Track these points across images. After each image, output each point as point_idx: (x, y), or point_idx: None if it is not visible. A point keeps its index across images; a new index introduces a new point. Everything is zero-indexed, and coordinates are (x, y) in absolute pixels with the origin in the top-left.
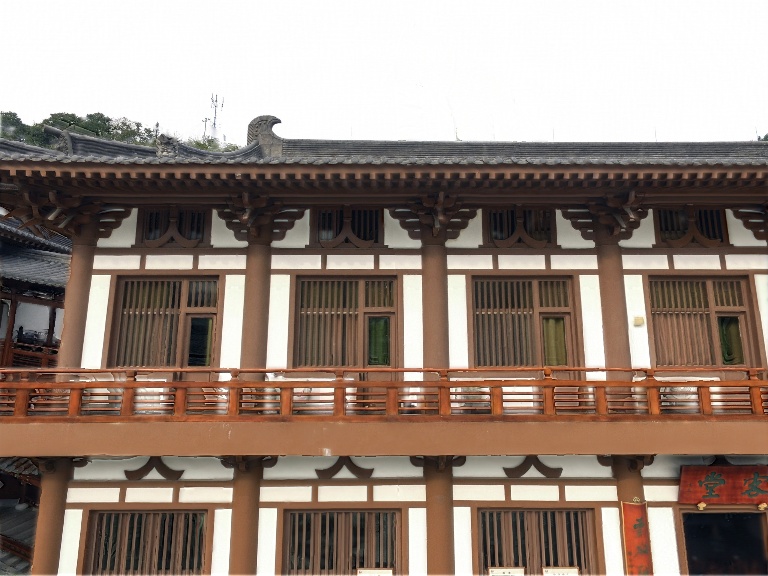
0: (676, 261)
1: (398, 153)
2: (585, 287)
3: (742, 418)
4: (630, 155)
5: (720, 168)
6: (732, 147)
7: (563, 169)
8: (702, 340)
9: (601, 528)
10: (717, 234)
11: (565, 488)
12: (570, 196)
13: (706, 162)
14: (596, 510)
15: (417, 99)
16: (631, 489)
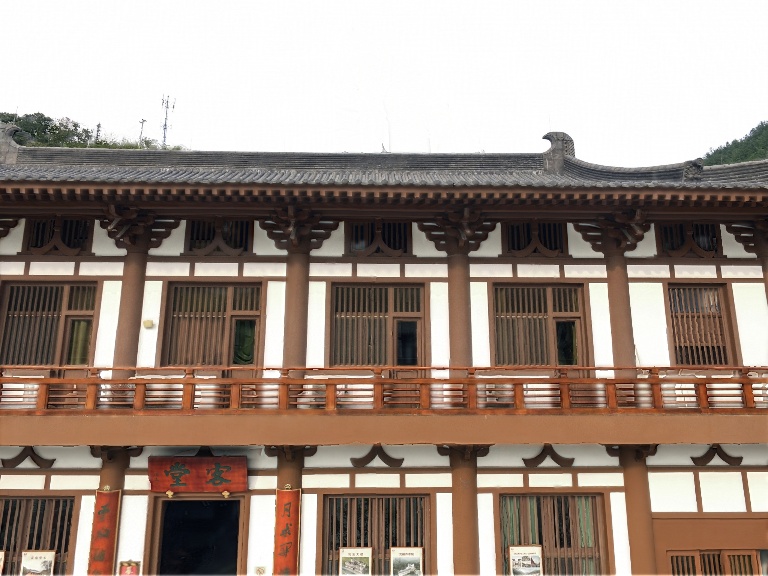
0: (197, 268)
1: (129, 161)
2: (107, 292)
3: (168, 413)
4: (354, 165)
5: (147, 185)
6: (452, 158)
7: (3, 184)
8: (214, 341)
9: (78, 514)
10: (243, 244)
11: (51, 478)
12: (72, 208)
13: (132, 179)
14: (76, 498)
15: (354, 103)
16: (106, 478)
